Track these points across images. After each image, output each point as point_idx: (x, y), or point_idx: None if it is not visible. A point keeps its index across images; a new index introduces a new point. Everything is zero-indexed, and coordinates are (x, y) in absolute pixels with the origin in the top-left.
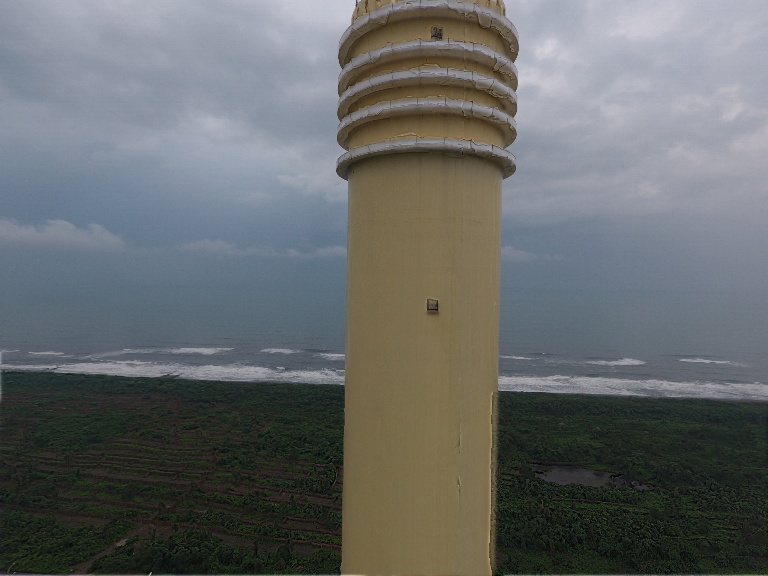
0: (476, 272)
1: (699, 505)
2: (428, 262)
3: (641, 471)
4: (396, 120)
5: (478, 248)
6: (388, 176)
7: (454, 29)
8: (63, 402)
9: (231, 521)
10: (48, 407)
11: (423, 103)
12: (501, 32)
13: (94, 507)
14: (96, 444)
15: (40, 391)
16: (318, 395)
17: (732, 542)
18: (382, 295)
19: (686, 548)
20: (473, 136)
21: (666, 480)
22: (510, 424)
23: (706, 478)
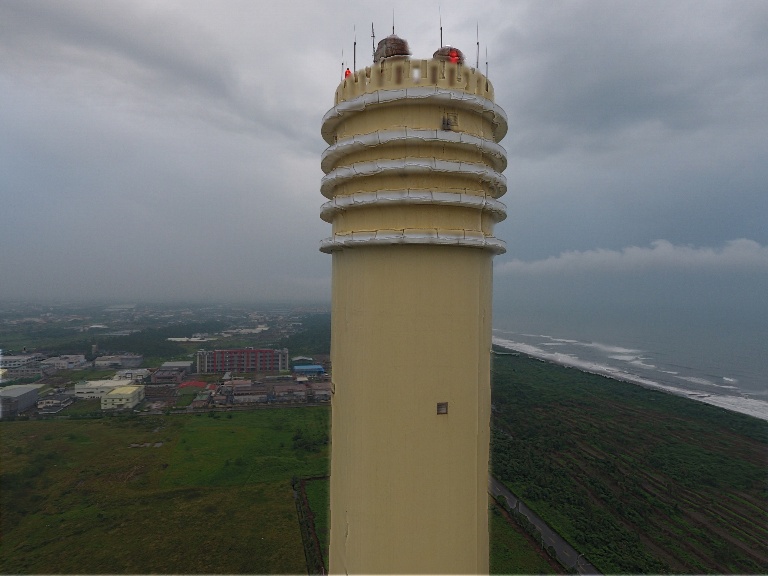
0: (357, 363)
1: None
2: None
3: None
4: None
5: (359, 338)
6: None
7: (341, 130)
8: (692, 432)
9: None
10: (676, 432)
11: None
12: (381, 101)
13: (679, 548)
14: (711, 487)
15: (675, 415)
16: None
17: None
18: None
19: None
20: (355, 224)
21: None
22: None
23: None
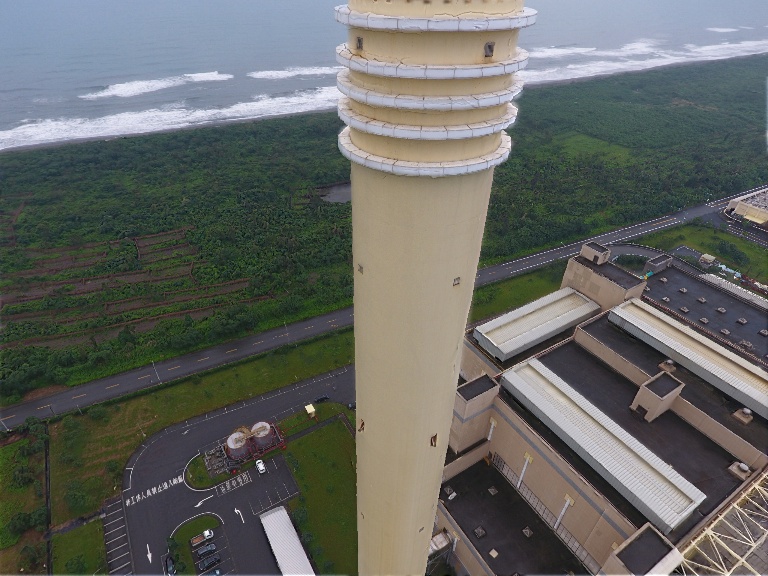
0: None
1: None
2: (456, 253)
3: None
4: (445, 144)
5: None
6: (431, 192)
7: (502, 42)
8: None
9: (46, 327)
10: None
11: (477, 135)
12: None
13: None
14: None
15: None
16: (65, 160)
17: None
18: (419, 282)
19: None
20: (495, 141)
21: None
22: (289, 154)
23: None
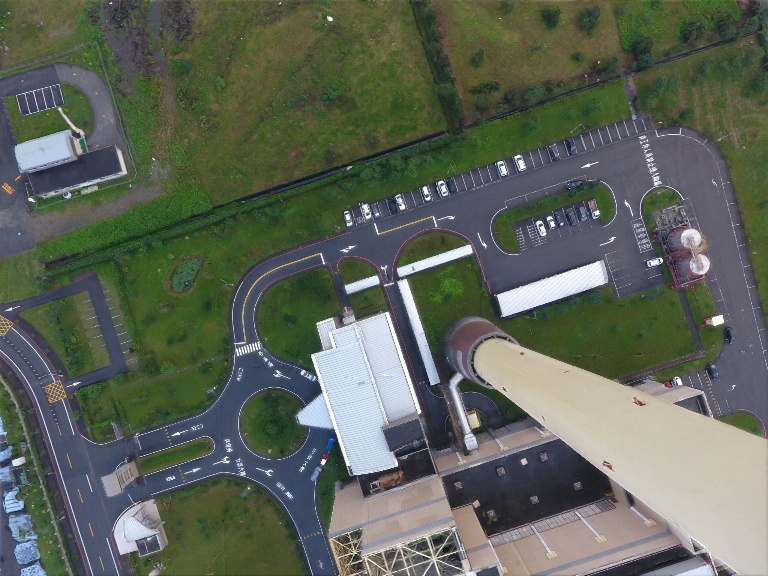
0: None
1: None
2: None
3: None
4: None
5: None
6: None
7: None
8: None
9: None
10: None
11: None
12: None
13: None
14: None
15: None
16: None
17: None
18: None
19: None
20: None
21: None
22: None
23: None
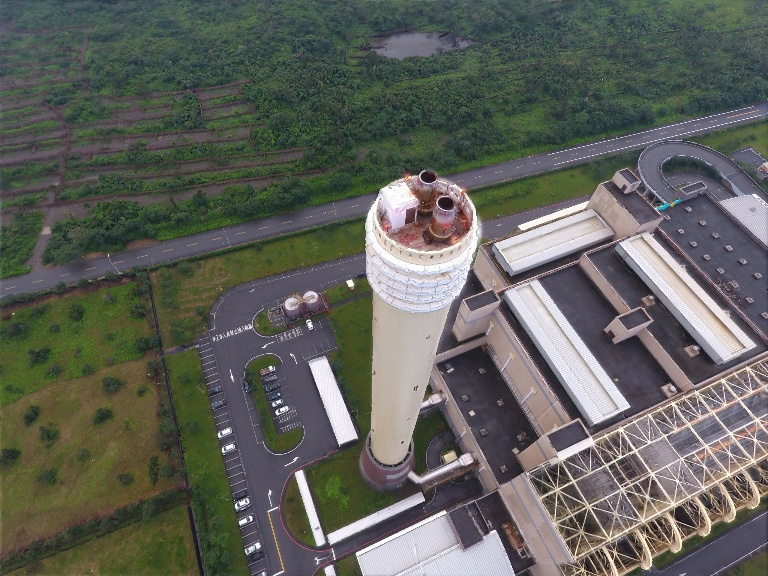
0: None
1: (503, 58)
2: None
3: (464, 26)
4: None
5: None
6: None
7: None
8: None
9: (131, 182)
10: None
11: None
12: None
13: None
14: None
15: None
16: None
17: (518, 92)
18: None
19: (488, 109)
20: None
21: (482, 33)
22: None
23: (513, 23)
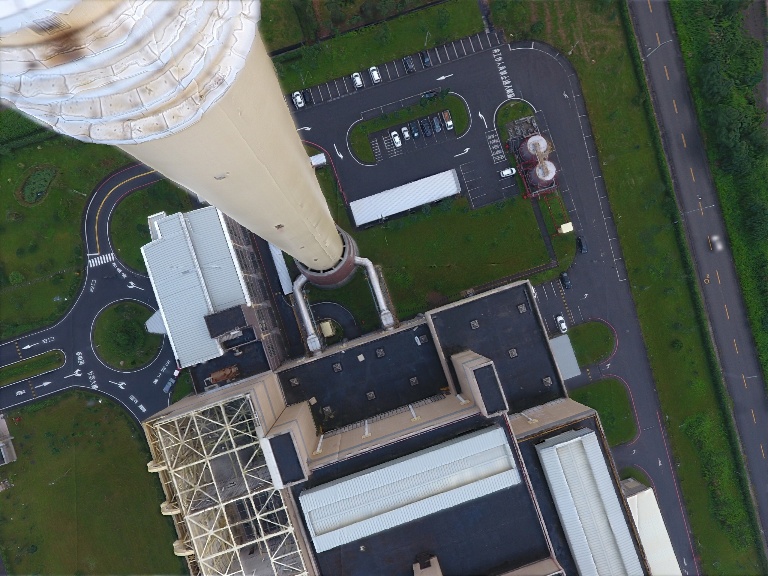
0: None
1: None
2: None
3: None
4: None
5: None
6: None
7: None
8: None
9: None
10: None
11: None
12: None
13: None
14: None
15: None
16: None
17: None
18: None
19: None
20: None
21: None
22: None
23: None
